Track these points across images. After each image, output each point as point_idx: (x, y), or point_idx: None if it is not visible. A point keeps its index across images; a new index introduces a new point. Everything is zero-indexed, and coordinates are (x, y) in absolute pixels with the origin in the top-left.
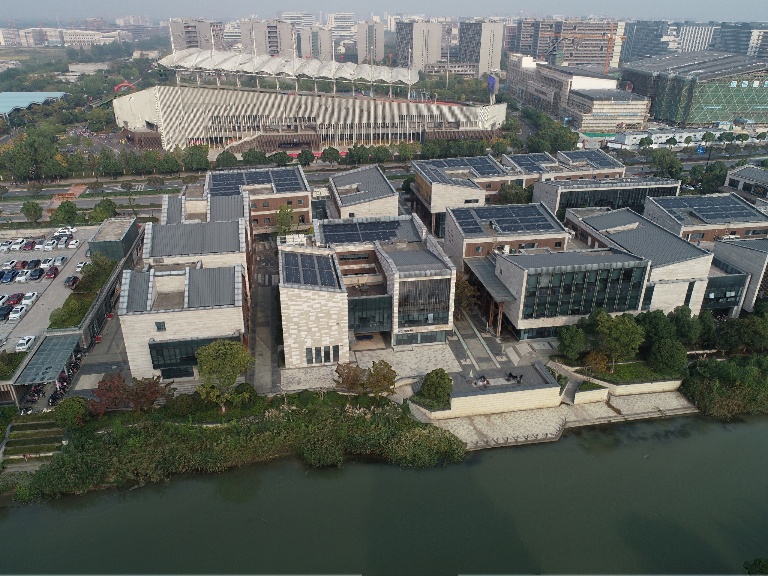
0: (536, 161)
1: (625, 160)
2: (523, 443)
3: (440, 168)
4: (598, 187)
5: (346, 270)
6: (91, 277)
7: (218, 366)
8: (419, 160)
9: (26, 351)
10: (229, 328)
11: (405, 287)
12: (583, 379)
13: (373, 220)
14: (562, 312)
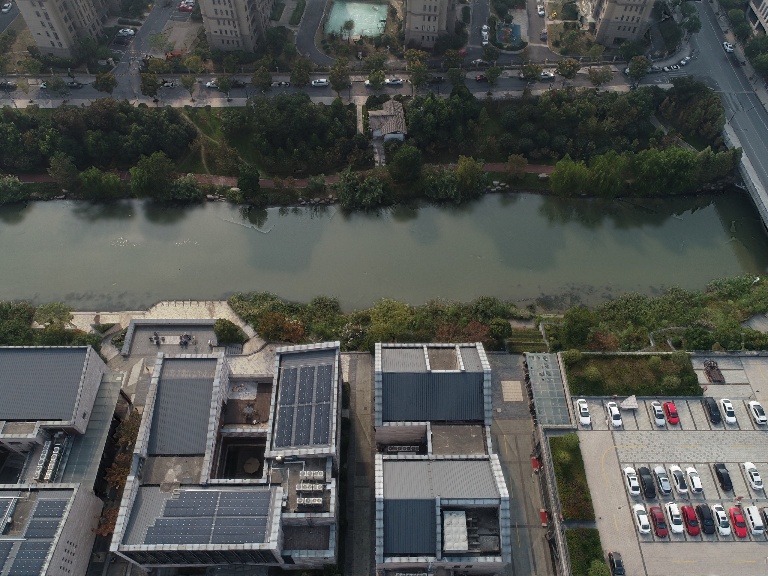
0: None
1: None
2: None
3: None
4: None
5: None
6: None
7: None
8: None
9: None
10: None
11: None
12: None
13: None
14: None
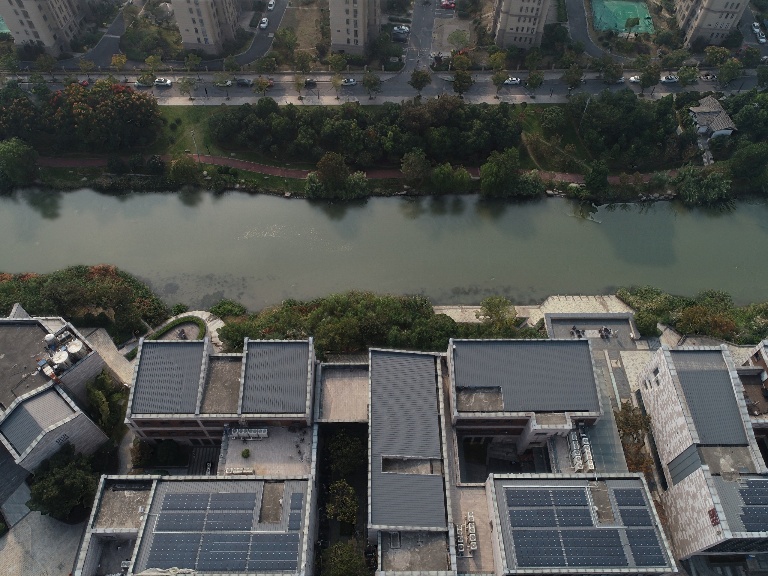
0: None
1: None
2: None
3: None
4: None
5: None
6: None
7: None
8: None
9: None
10: None
11: None
12: None
13: None
14: None
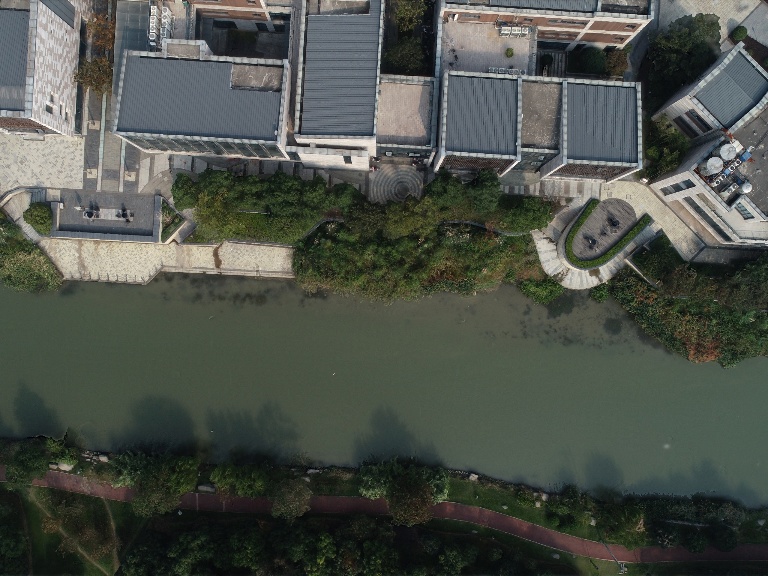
0: None
1: None
2: (115, 282)
3: None
4: None
5: None
6: None
7: None
8: None
9: None
10: None
11: None
12: None
13: None
14: None
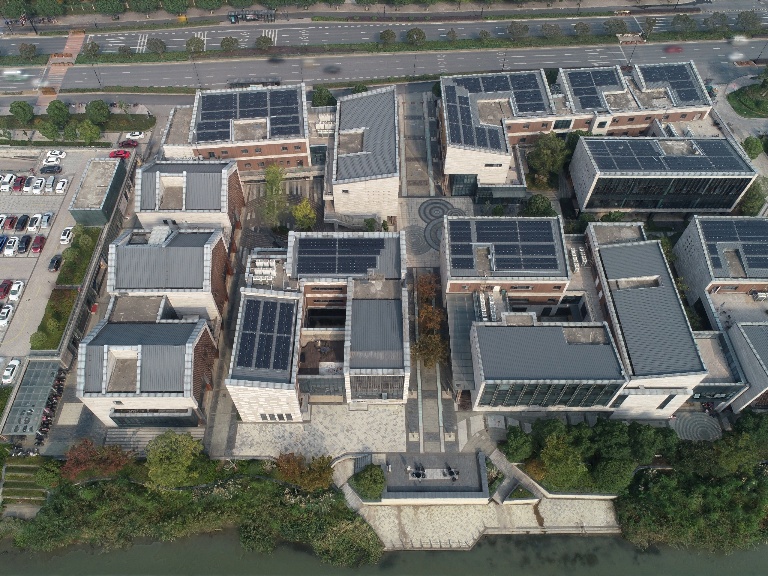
0: (599, 85)
1: (746, 29)
2: (437, 549)
3: (473, 94)
4: (647, 175)
5: (319, 297)
6: (73, 263)
7: (163, 471)
8: (451, 76)
9: (12, 382)
10: (182, 406)
11: (357, 379)
12: (522, 475)
13: (355, 236)
14: (522, 403)
